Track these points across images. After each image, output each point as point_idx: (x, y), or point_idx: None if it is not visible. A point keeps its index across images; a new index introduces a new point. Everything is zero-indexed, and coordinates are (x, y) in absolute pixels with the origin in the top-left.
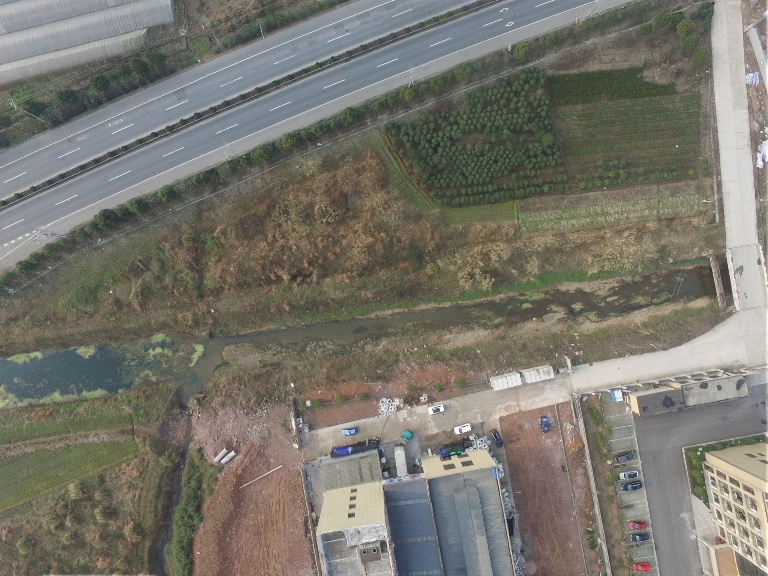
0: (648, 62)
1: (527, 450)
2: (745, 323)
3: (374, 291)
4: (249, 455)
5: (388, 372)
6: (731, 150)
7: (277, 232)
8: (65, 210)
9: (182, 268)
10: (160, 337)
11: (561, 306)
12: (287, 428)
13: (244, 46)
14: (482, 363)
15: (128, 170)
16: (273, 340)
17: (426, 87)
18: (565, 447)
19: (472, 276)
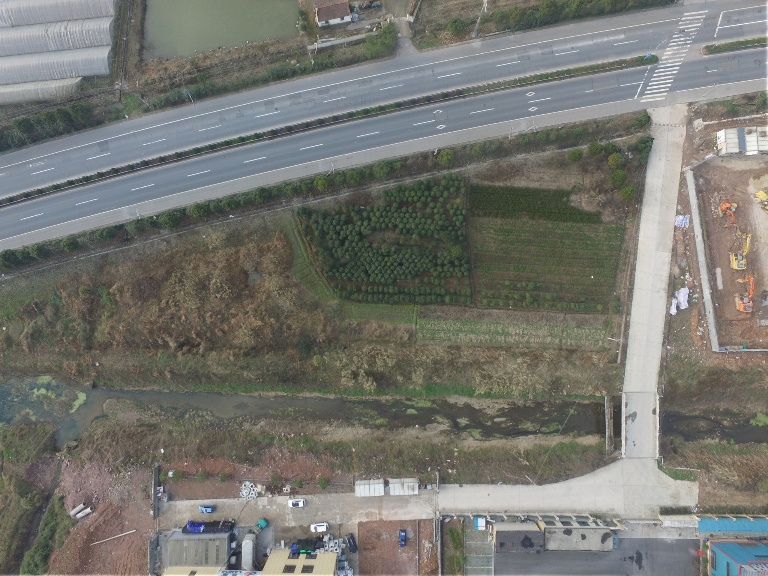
0: (577, 187)
1: (381, 560)
2: (628, 472)
3: (257, 373)
4: (104, 514)
5: (258, 455)
6: (646, 291)
7: (171, 299)
8: None
9: (75, 317)
10: (46, 378)
11: (446, 418)
12: (147, 494)
13: (173, 109)
14: (353, 463)
15: (40, 212)
16: (154, 401)
17: (341, 180)
18: (420, 565)
19: (355, 376)
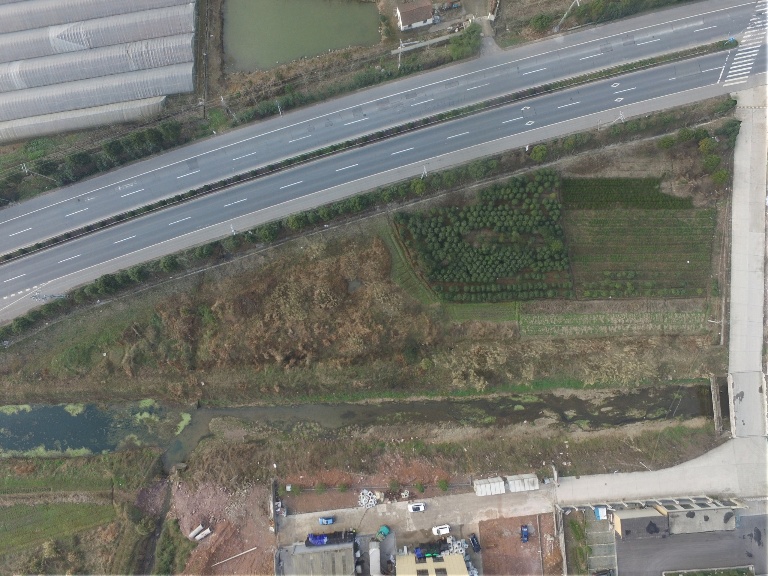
0: (667, 174)
1: (504, 558)
2: (740, 451)
3: (366, 381)
4: (224, 534)
5: (372, 463)
6: (743, 272)
7: (275, 312)
8: (67, 269)
9: (177, 338)
10: (149, 402)
11: (554, 411)
12: (265, 510)
13: (261, 122)
14: (468, 463)
15: (133, 235)
16: (260, 416)
17: (438, 182)
18: (543, 559)
19: (466, 376)
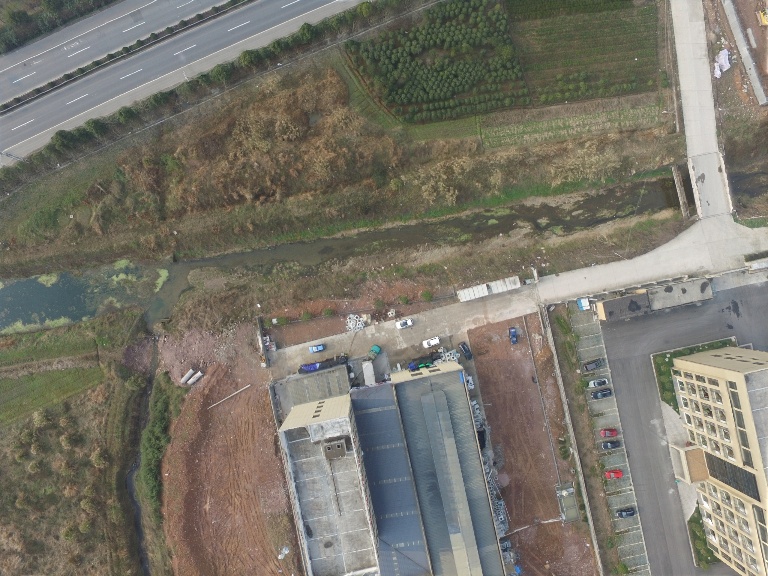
0: None
1: (496, 362)
2: (708, 230)
3: (338, 208)
4: (216, 375)
5: (355, 290)
6: (689, 60)
7: (238, 151)
8: (22, 135)
9: (143, 191)
10: (123, 263)
11: (527, 221)
12: (254, 347)
13: None
14: (449, 278)
15: (85, 93)
16: (239, 263)
17: (384, 1)
18: (534, 358)
19: (436, 189)
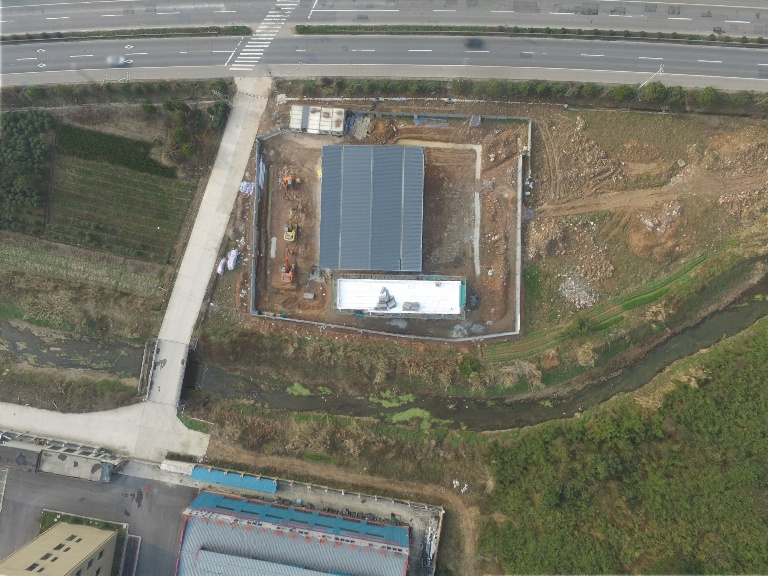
0: (157, 140)
1: None
2: (148, 414)
3: None
4: None
5: None
6: (198, 248)
7: None
8: None
9: None
10: None
11: (7, 339)
12: None
13: None
14: None
15: None
16: None
17: None
18: None
19: None
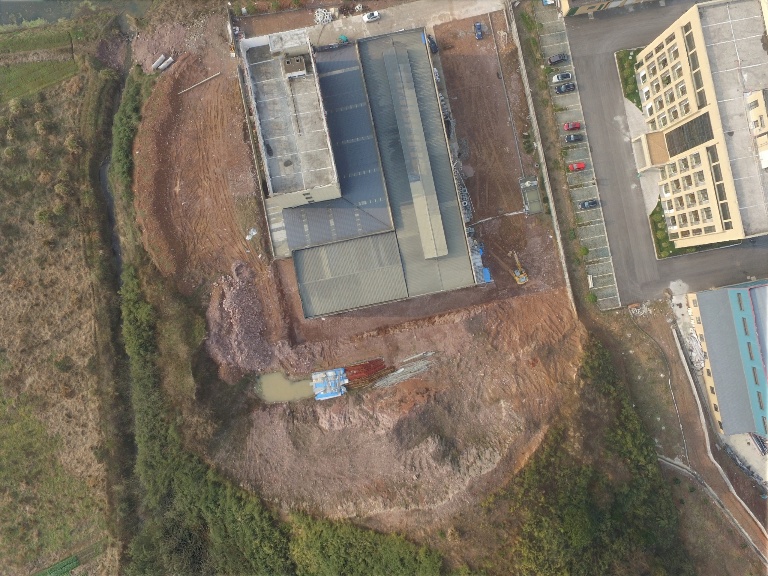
0: None
1: (462, 58)
2: None
3: None
4: (186, 61)
5: None
6: None
7: None
8: None
9: None
10: None
11: None
12: (224, 38)
13: None
14: None
15: None
16: None
17: None
18: (499, 54)
19: None
